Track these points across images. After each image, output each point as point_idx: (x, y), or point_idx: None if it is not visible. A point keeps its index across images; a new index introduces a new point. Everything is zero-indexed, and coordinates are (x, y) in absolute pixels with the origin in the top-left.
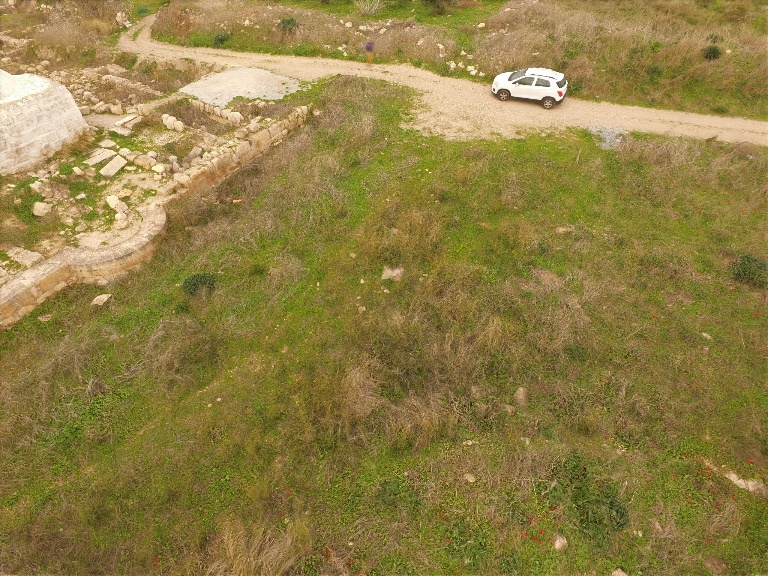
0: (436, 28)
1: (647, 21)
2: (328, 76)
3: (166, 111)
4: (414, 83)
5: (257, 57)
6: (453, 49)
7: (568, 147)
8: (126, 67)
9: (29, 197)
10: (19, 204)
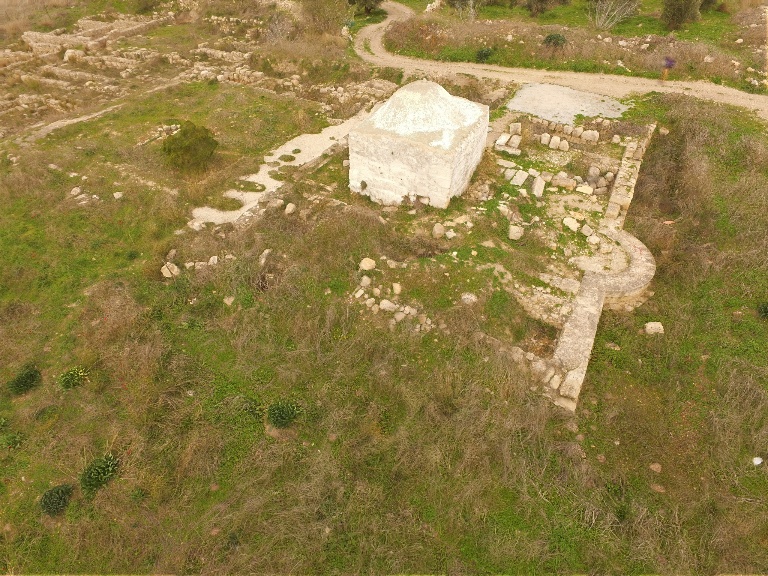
0: (698, 44)
1: None
2: (636, 93)
3: None
4: (730, 100)
5: (534, 73)
6: (741, 66)
7: None
8: (395, 82)
9: (500, 220)
10: (498, 228)
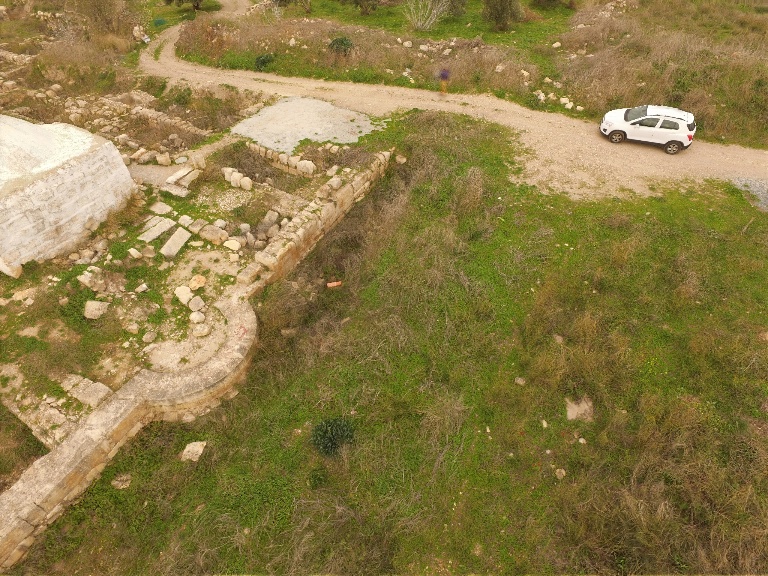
0: (507, 48)
1: (748, 43)
2: (401, 110)
3: (223, 160)
4: (503, 119)
5: (309, 83)
6: (537, 75)
7: (720, 209)
8: (154, 94)
9: (77, 294)
10: (66, 305)
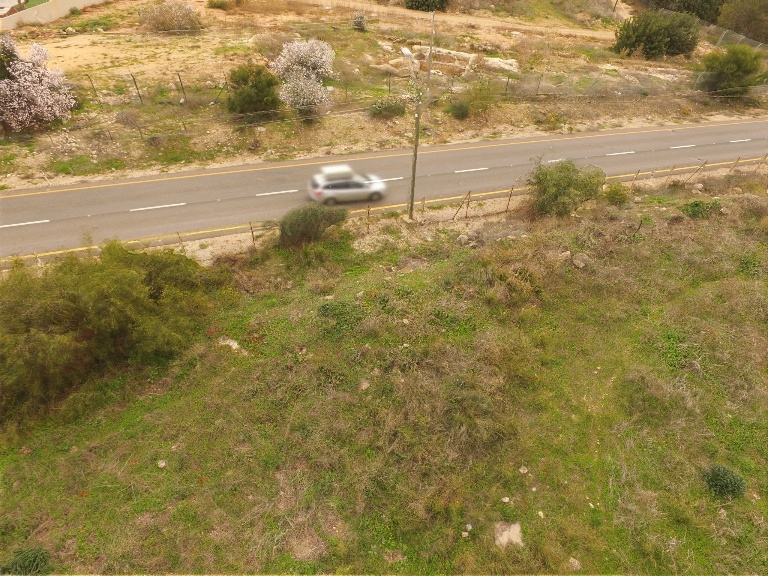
0: None
1: None
2: None
3: None
4: None
5: None
6: None
7: None
8: None
9: None
10: None
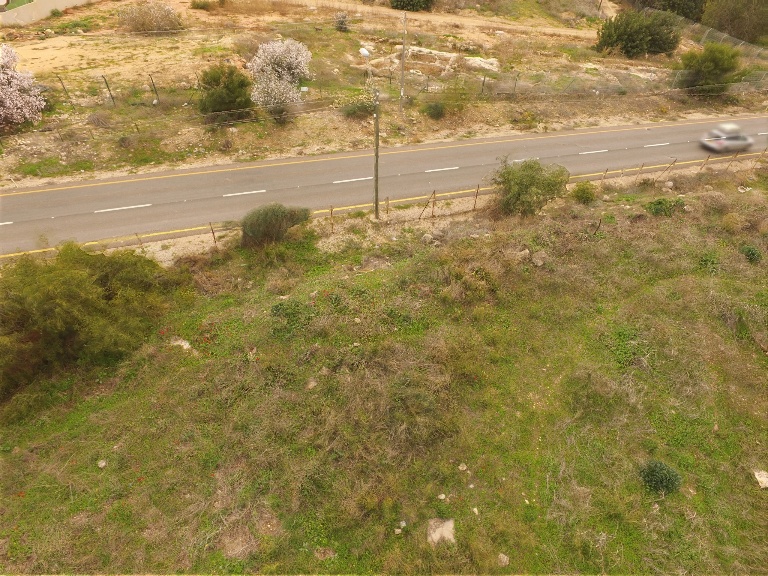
0: None
1: None
2: None
3: None
4: None
5: None
6: None
7: None
8: None
9: None
10: None
